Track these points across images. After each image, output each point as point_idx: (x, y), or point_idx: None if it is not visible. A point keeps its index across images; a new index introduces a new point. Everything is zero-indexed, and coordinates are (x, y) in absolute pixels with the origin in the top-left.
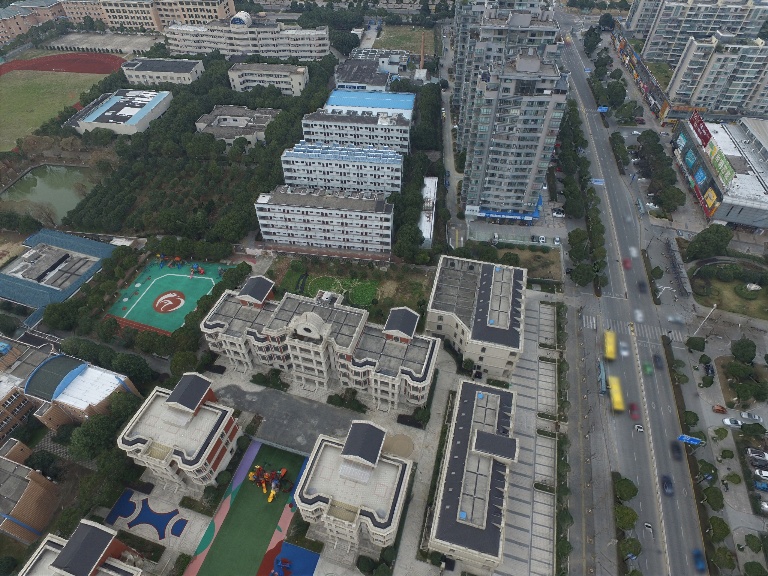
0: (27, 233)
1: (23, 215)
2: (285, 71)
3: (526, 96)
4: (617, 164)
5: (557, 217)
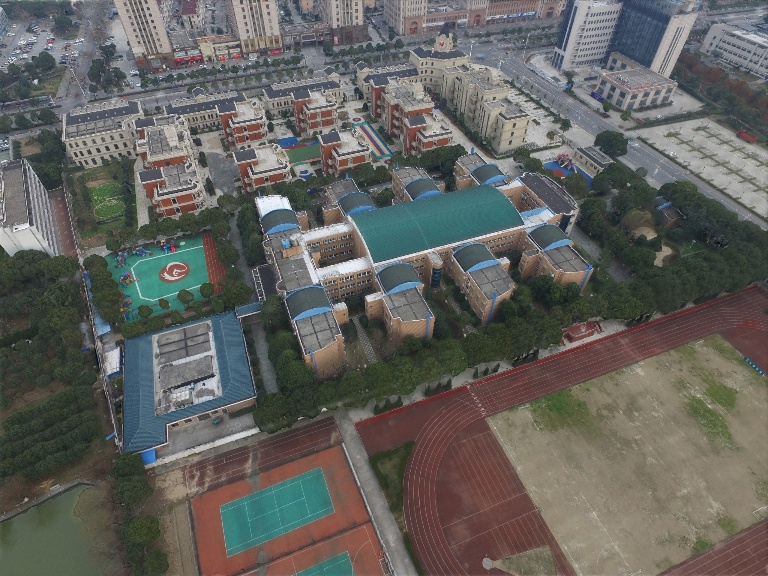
0: None
1: None
2: None
3: None
4: None
5: None
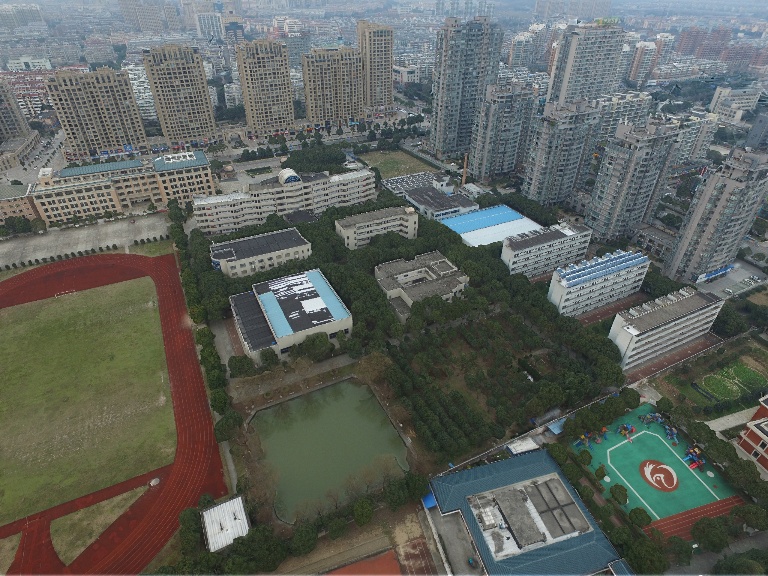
0: None
1: (404, 477)
2: (394, 215)
3: (761, 180)
4: None
5: None
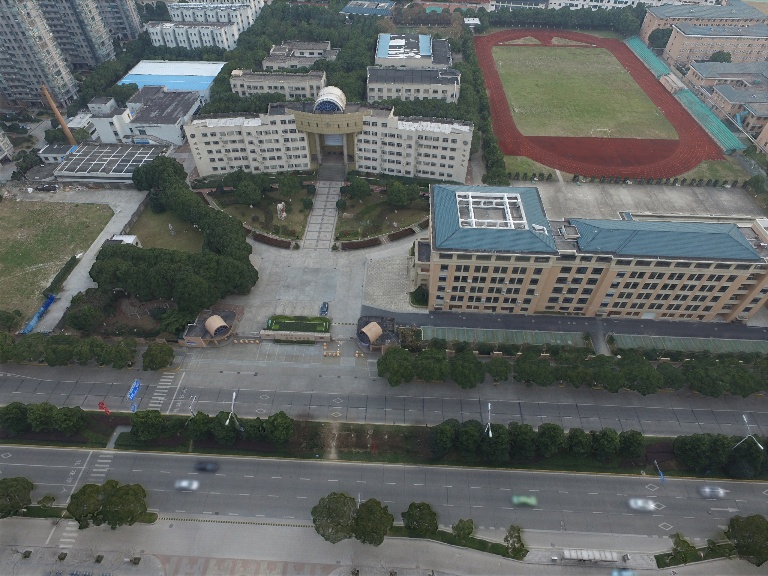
0: None
1: None
2: (257, 76)
3: None
4: None
5: None
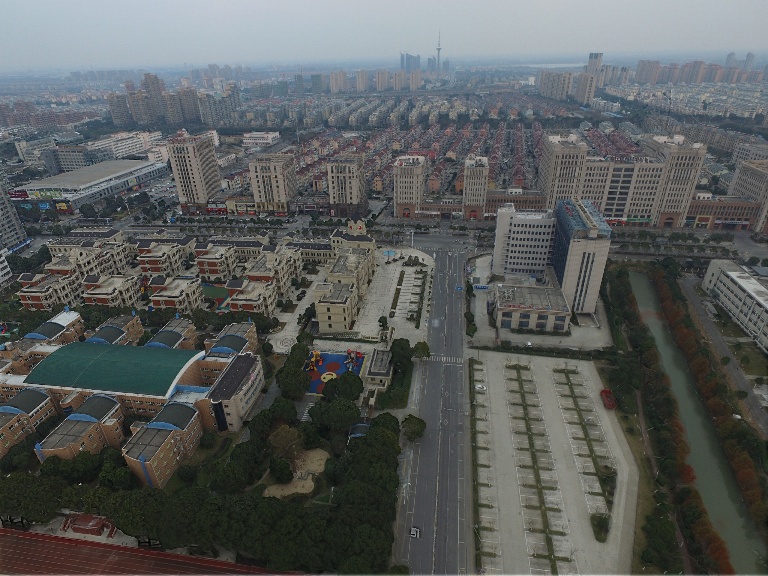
0: None
1: None
2: None
3: None
4: None
5: None
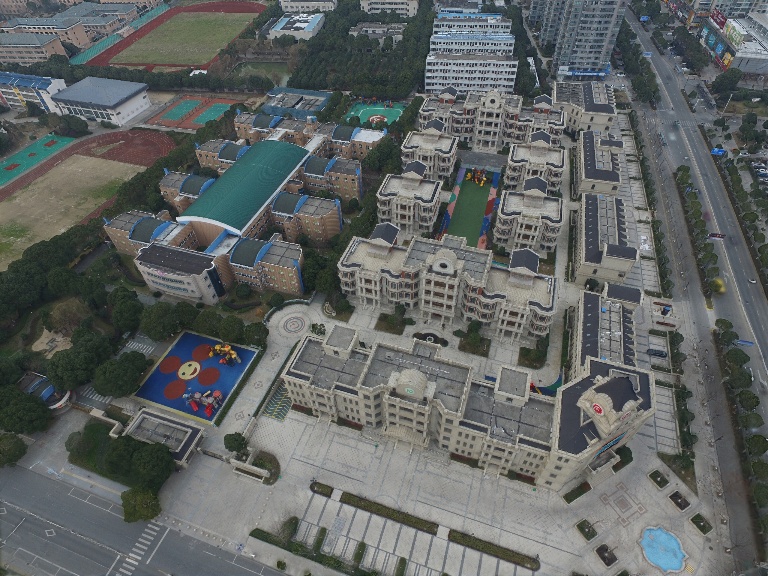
0: (267, 90)
1: (264, 78)
2: None
3: None
4: (658, 50)
5: (620, 77)
